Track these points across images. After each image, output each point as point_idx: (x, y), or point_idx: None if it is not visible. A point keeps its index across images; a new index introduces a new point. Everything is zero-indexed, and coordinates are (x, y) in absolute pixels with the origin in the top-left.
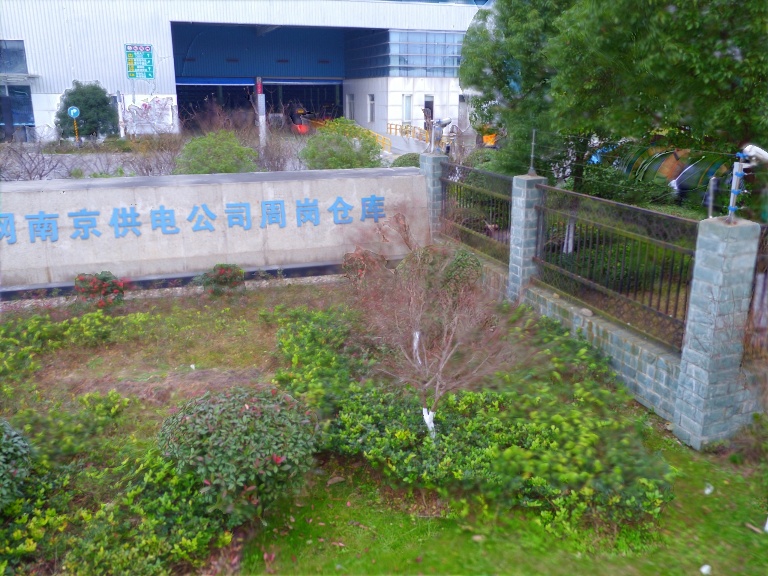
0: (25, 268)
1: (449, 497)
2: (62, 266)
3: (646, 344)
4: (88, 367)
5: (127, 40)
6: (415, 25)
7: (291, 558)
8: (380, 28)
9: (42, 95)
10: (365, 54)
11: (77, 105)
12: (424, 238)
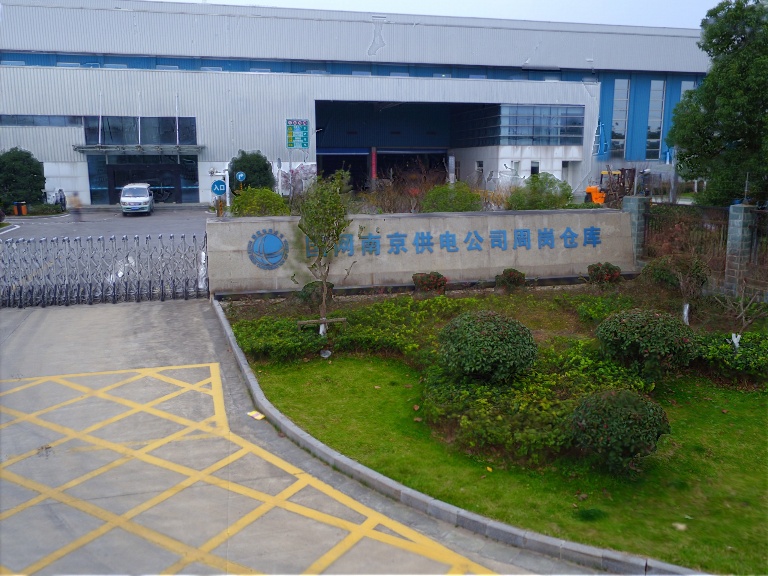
0: (358, 273)
1: (764, 380)
2: (381, 273)
3: None
4: None
5: (279, 116)
6: (524, 100)
7: (686, 402)
8: (493, 103)
9: (207, 163)
10: (473, 126)
11: (243, 170)
12: (629, 260)
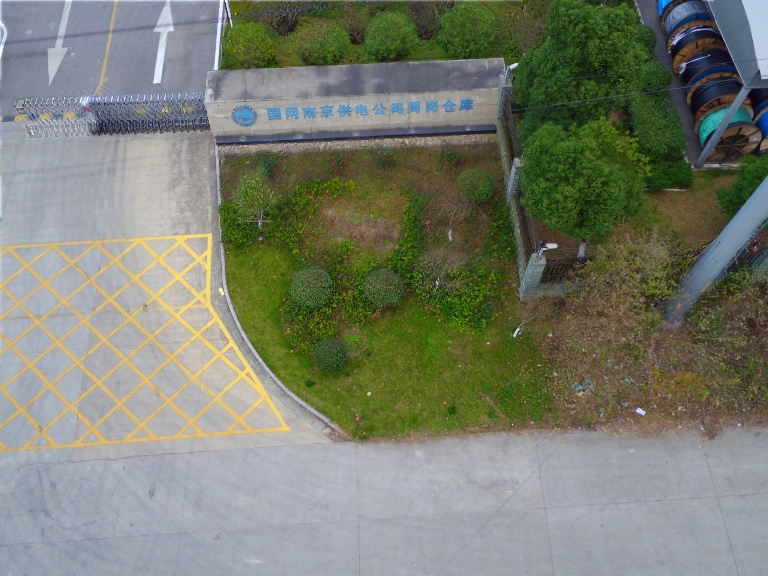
0: (302, 128)
1: None
2: (317, 127)
3: (524, 261)
4: (335, 208)
5: None
6: None
7: (392, 316)
8: None
9: None
10: None
11: None
12: (493, 118)
